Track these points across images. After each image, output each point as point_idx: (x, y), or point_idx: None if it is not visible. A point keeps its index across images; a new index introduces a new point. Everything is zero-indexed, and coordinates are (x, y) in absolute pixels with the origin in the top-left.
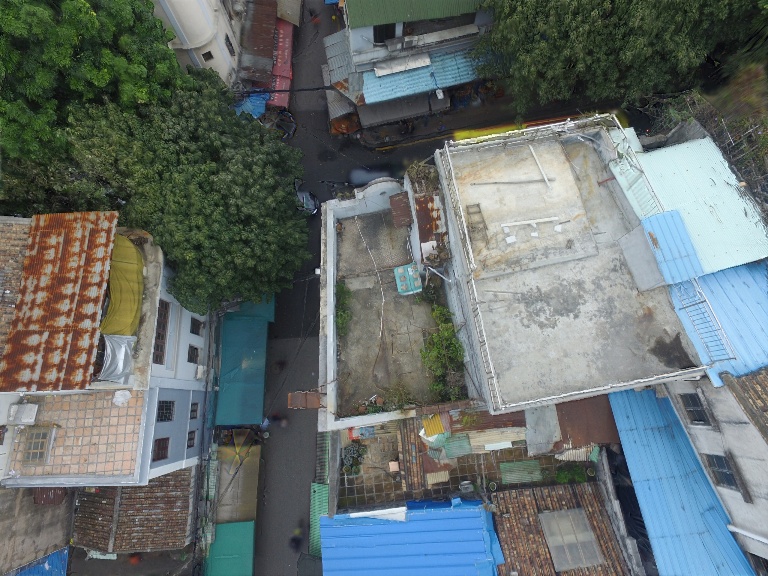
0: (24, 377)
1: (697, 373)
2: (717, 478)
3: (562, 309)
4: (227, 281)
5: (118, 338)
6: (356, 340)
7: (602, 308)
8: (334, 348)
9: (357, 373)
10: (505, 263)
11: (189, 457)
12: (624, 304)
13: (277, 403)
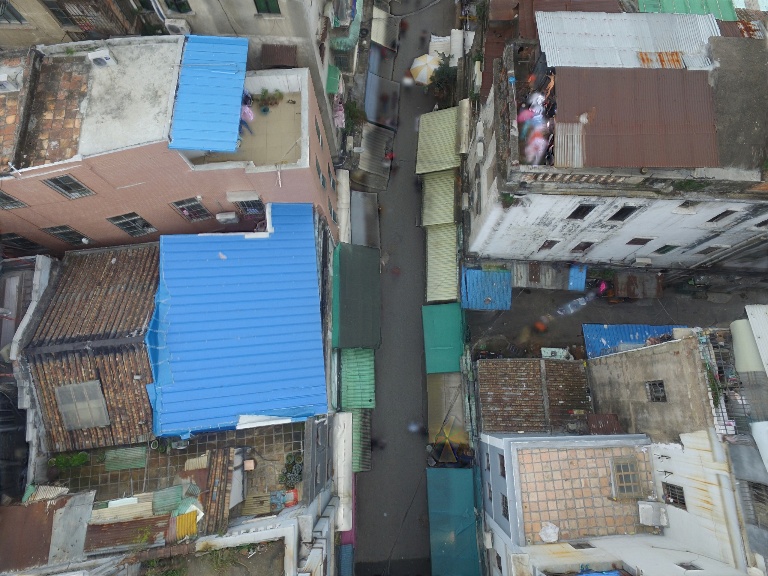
0: None
1: None
2: None
3: None
4: None
5: None
6: None
7: None
8: None
9: None
10: None
11: None
12: None
13: (422, 481)
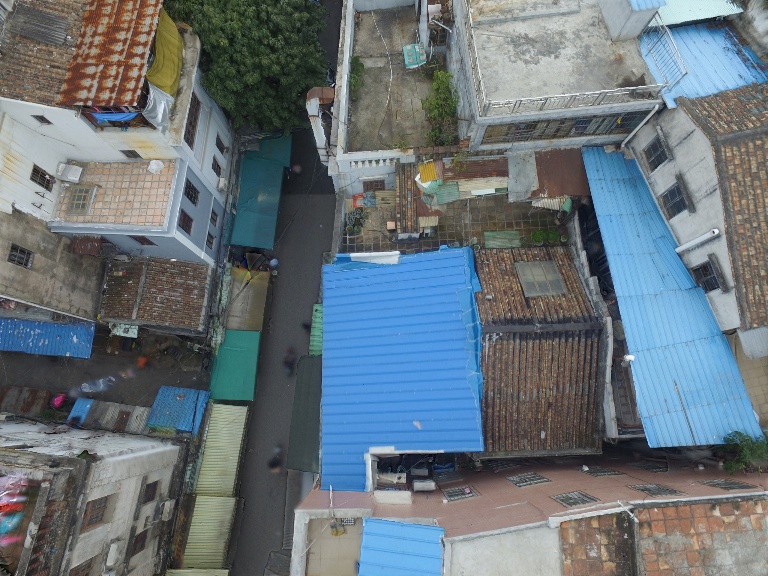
0: (82, 95)
1: (656, 100)
2: (670, 214)
3: (545, 51)
4: (254, 82)
5: (159, 92)
6: (366, 107)
7: (579, 52)
8: (346, 104)
9: (365, 132)
10: (499, 12)
11: (207, 254)
12: (599, 50)
13: (286, 248)
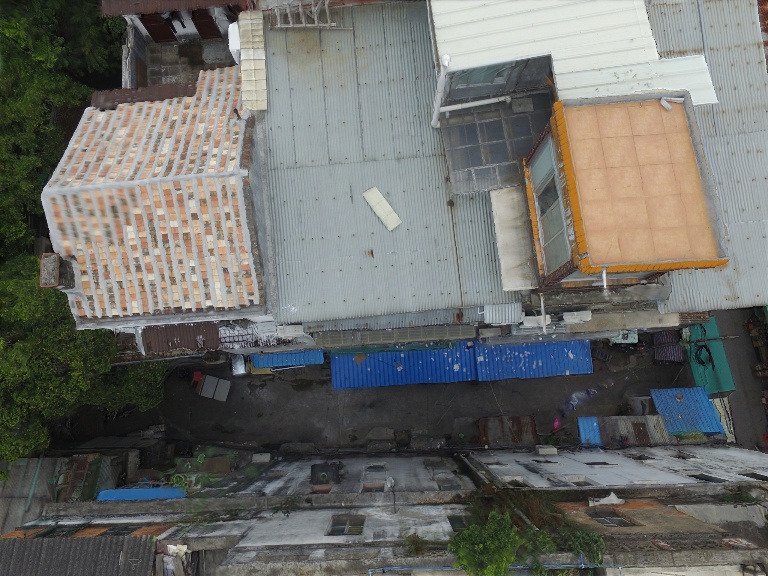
0: None
1: None
2: None
3: None
4: None
5: None
6: None
7: None
8: None
9: None
10: None
11: None
12: None
13: None
